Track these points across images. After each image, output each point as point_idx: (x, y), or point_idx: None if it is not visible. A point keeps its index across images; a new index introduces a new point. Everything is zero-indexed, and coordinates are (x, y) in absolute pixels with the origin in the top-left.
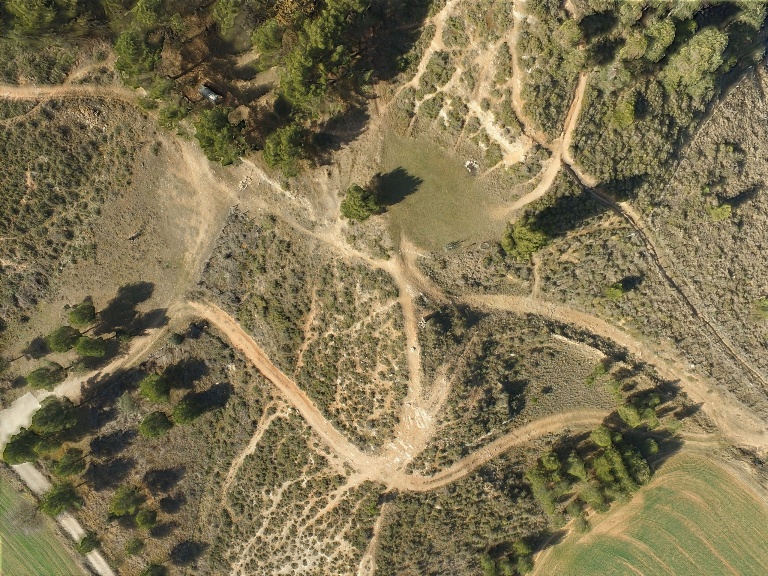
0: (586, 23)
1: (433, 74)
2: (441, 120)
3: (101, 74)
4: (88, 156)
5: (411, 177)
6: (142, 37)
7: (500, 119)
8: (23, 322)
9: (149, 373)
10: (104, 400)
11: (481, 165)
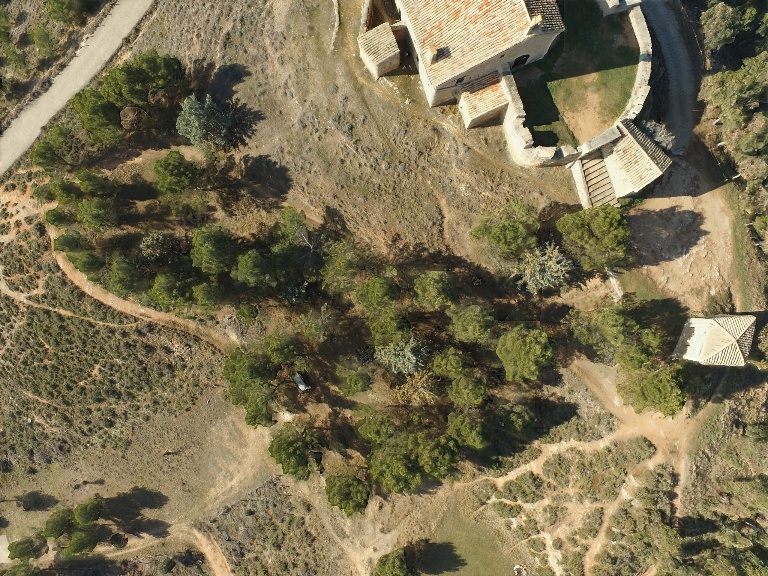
0: (686, 522)
1: (520, 489)
2: (509, 523)
3: None
4: (160, 374)
5: (458, 556)
6: (260, 368)
7: (566, 564)
8: (29, 473)
9: (127, 572)
10: (73, 575)
11: (529, 573)
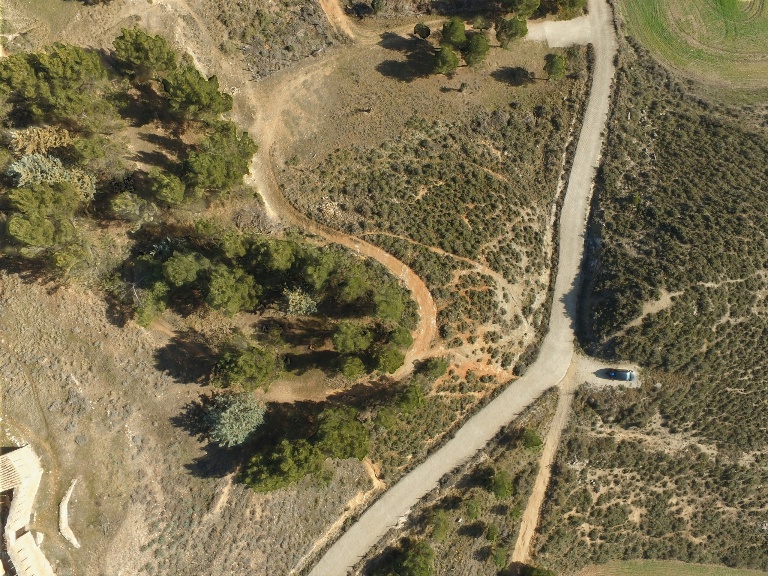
0: None
1: None
2: None
3: (296, 233)
4: None
5: None
6: None
7: None
8: None
9: (428, 3)
10: (484, 4)
11: None
